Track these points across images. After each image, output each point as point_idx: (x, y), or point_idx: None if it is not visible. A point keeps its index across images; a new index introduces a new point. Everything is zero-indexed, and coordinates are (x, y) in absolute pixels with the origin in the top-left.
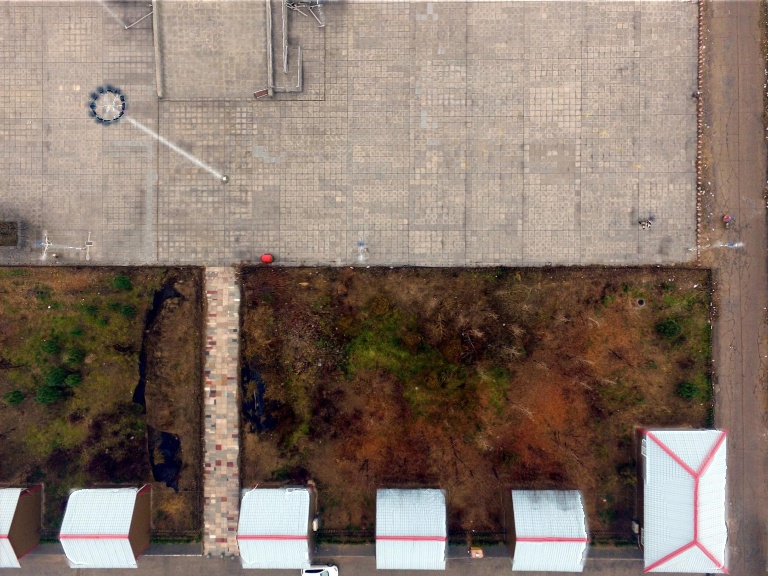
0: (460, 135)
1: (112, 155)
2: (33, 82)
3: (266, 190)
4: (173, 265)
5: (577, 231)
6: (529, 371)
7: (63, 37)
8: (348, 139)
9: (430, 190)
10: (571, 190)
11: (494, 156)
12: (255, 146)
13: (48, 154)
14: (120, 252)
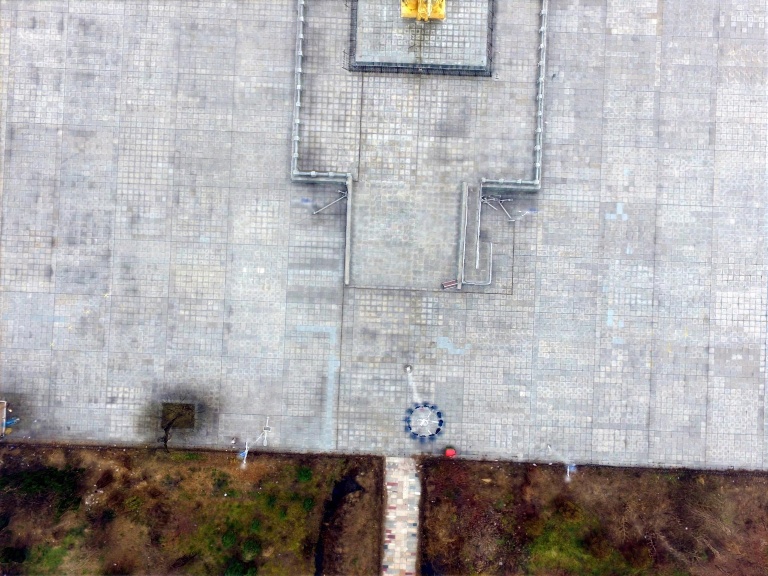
0: (646, 335)
1: (294, 340)
2: (217, 262)
3: (450, 381)
4: (352, 454)
5: (760, 436)
6: (710, 575)
7: (249, 219)
8: (534, 334)
9: (615, 389)
10: (755, 395)
11: (679, 357)
12: (440, 337)
13: (229, 336)
14: (298, 439)
